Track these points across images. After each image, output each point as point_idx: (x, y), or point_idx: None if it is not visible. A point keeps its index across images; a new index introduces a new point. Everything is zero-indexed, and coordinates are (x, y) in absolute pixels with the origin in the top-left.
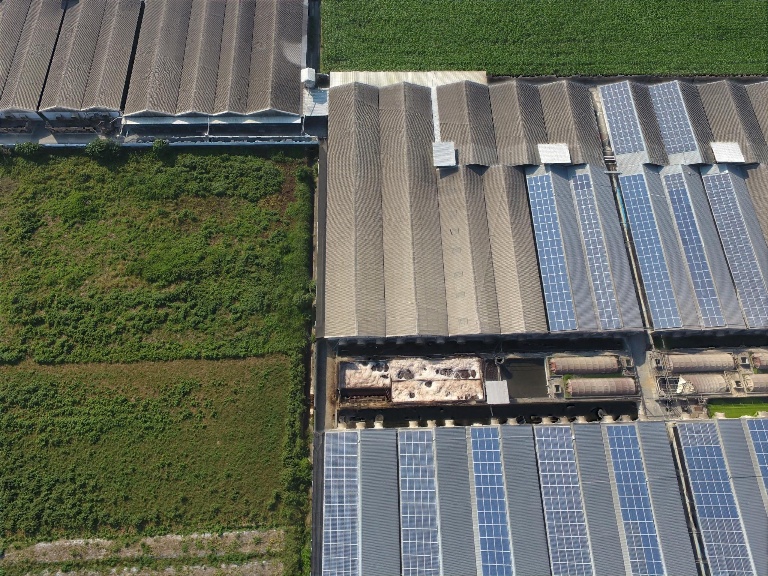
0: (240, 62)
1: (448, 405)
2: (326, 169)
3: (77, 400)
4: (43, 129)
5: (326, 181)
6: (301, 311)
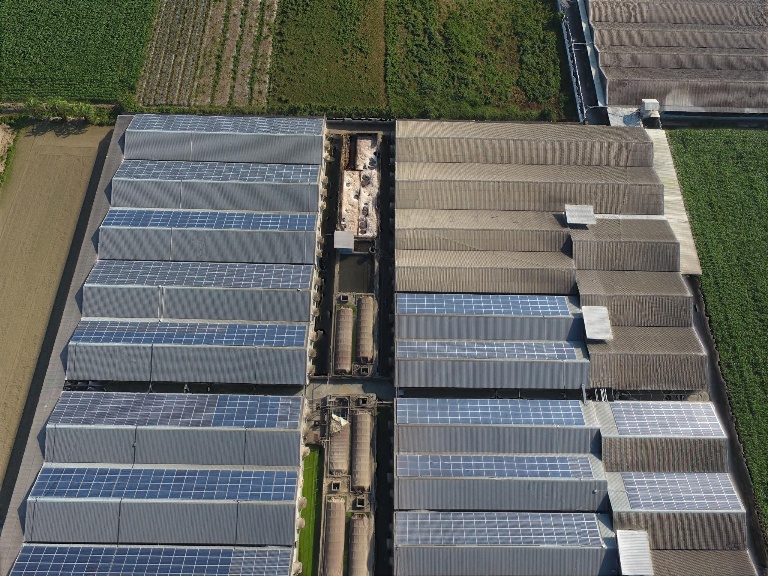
0: (656, 59)
1: None
2: None
3: None
4: None
5: None
6: (421, 114)
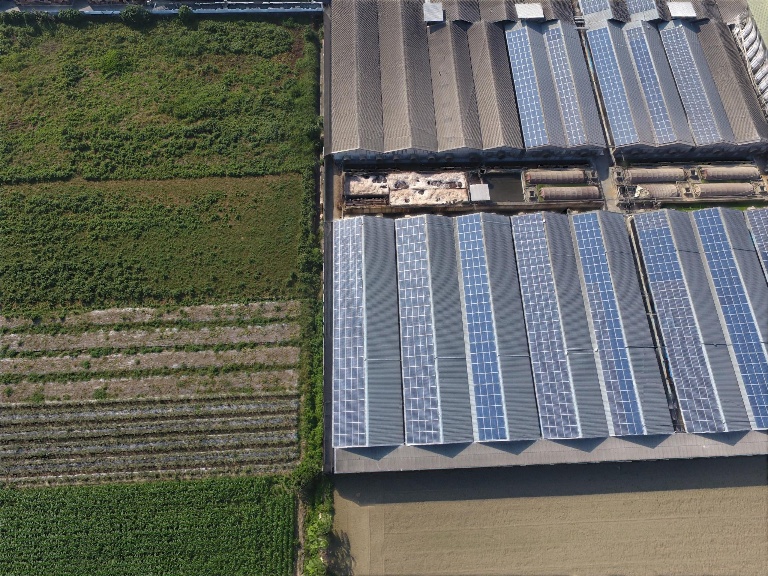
0: None
1: (438, 210)
2: (330, 27)
3: (121, 206)
4: (81, 2)
5: (331, 36)
6: (311, 139)
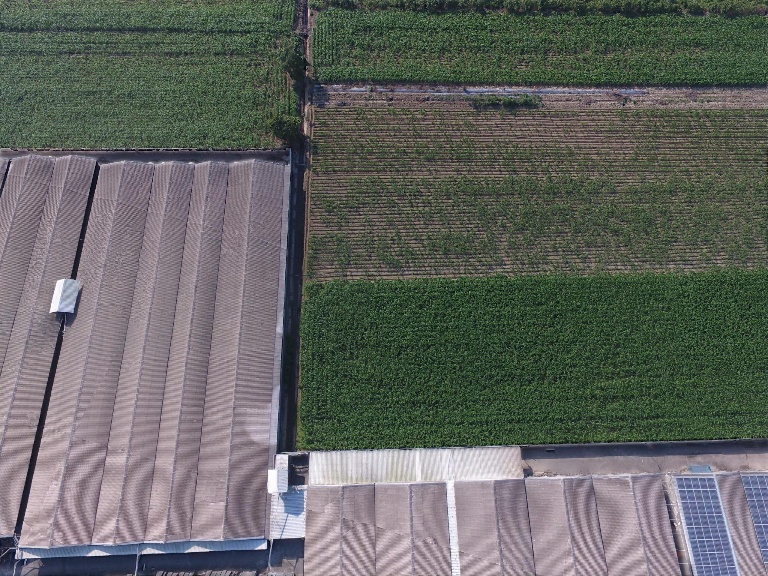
0: (186, 445)
1: None
2: None
3: None
4: None
5: None
6: None
